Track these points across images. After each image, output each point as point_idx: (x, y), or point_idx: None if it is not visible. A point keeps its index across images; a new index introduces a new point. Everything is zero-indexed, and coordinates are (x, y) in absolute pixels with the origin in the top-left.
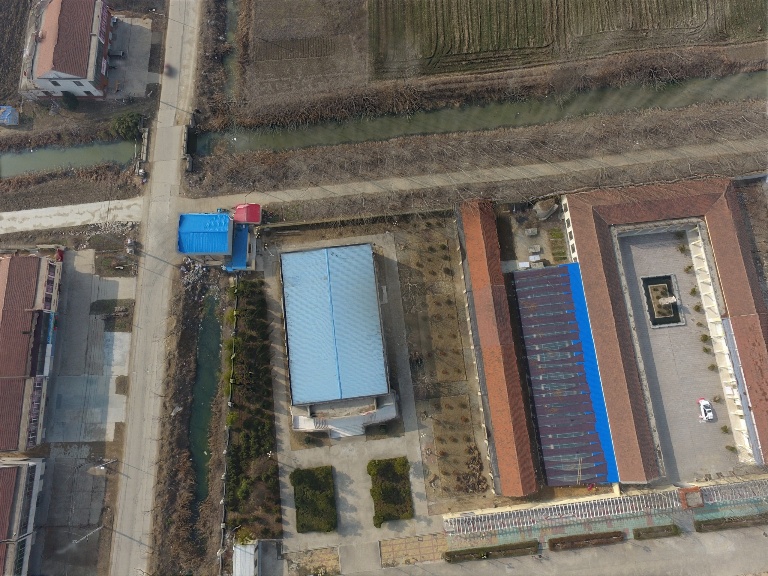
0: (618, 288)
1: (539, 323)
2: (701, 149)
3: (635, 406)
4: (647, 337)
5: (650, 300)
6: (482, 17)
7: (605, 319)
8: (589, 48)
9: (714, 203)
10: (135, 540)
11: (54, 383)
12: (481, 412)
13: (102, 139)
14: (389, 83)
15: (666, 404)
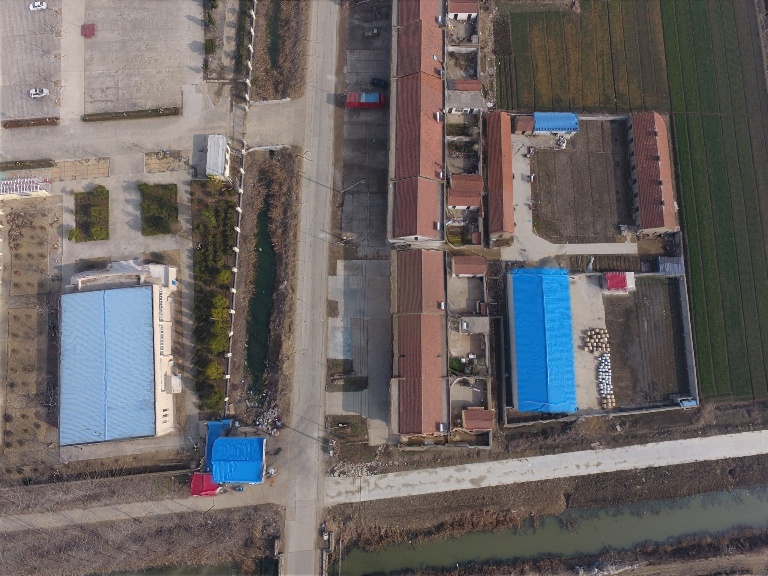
0: None
1: None
2: None
3: None
4: None
5: None
6: None
7: None
8: None
9: None
10: (314, 182)
11: None
12: None
13: None
14: None
15: None
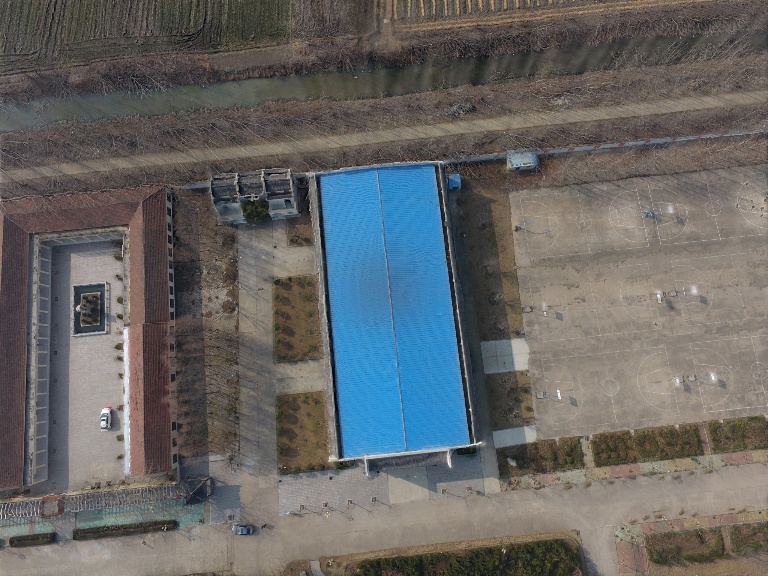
0: (21, 297)
1: None
2: (160, 157)
3: (5, 415)
4: (67, 345)
5: None
6: None
7: None
8: (76, 55)
9: (135, 212)
10: None
11: None
12: None
13: None
14: None
15: (71, 412)
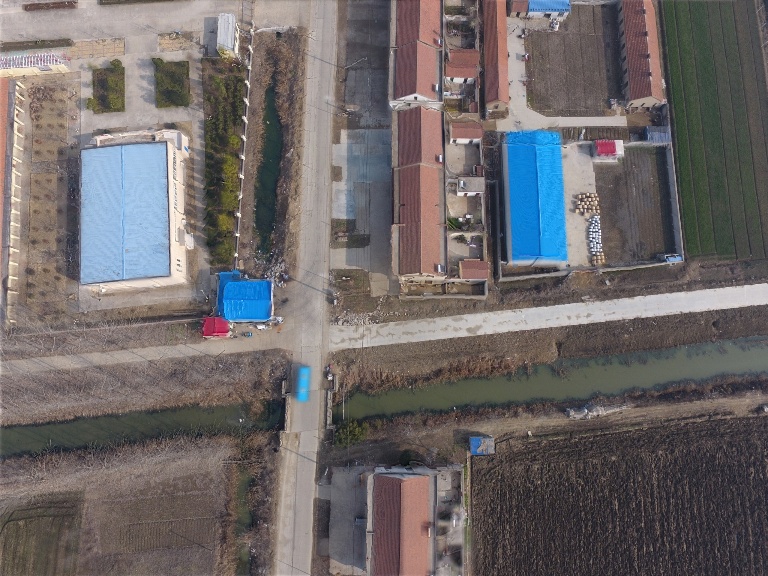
0: None
1: None
2: None
3: None
4: None
5: None
6: None
7: None
8: None
9: None
10: (319, 59)
11: None
12: (21, 146)
13: (382, 421)
14: (62, 487)
15: None
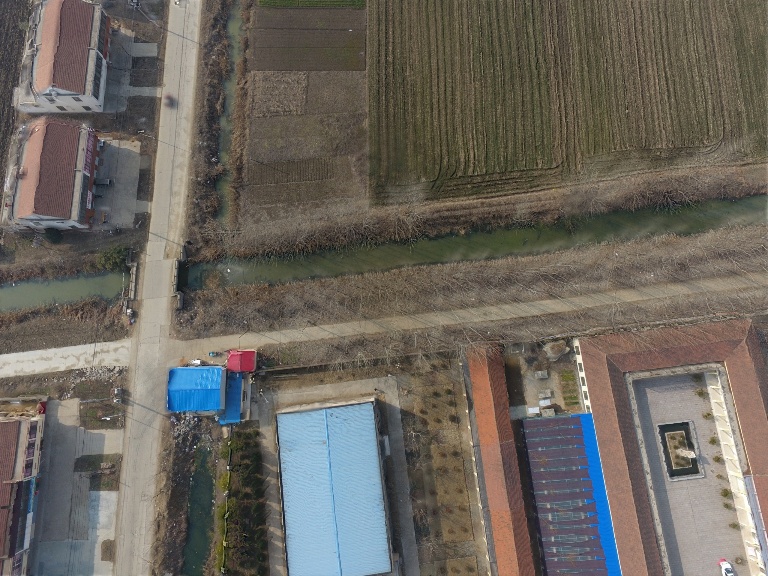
0: (634, 444)
1: (550, 479)
2: (719, 282)
3: None
4: (664, 491)
5: (667, 449)
6: (488, 136)
7: (621, 480)
8: (600, 169)
9: (734, 349)
10: None
11: (35, 552)
12: None
13: (88, 271)
14: (391, 209)
15: (685, 566)
